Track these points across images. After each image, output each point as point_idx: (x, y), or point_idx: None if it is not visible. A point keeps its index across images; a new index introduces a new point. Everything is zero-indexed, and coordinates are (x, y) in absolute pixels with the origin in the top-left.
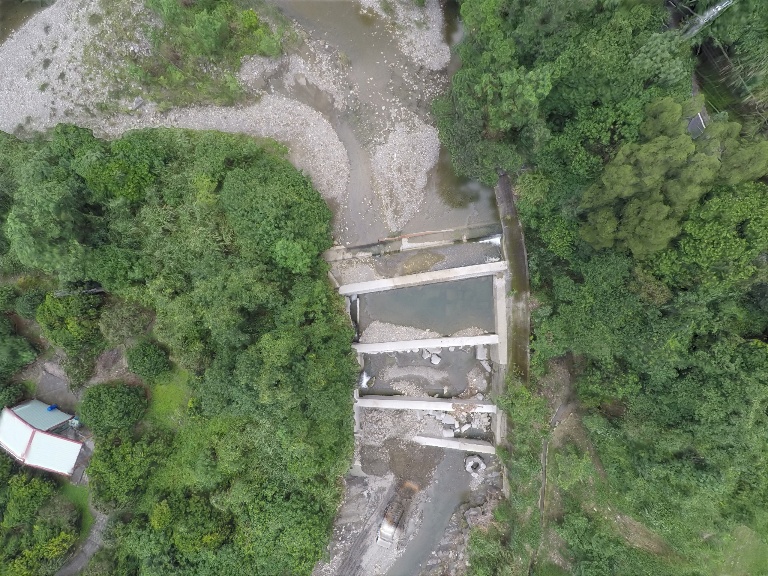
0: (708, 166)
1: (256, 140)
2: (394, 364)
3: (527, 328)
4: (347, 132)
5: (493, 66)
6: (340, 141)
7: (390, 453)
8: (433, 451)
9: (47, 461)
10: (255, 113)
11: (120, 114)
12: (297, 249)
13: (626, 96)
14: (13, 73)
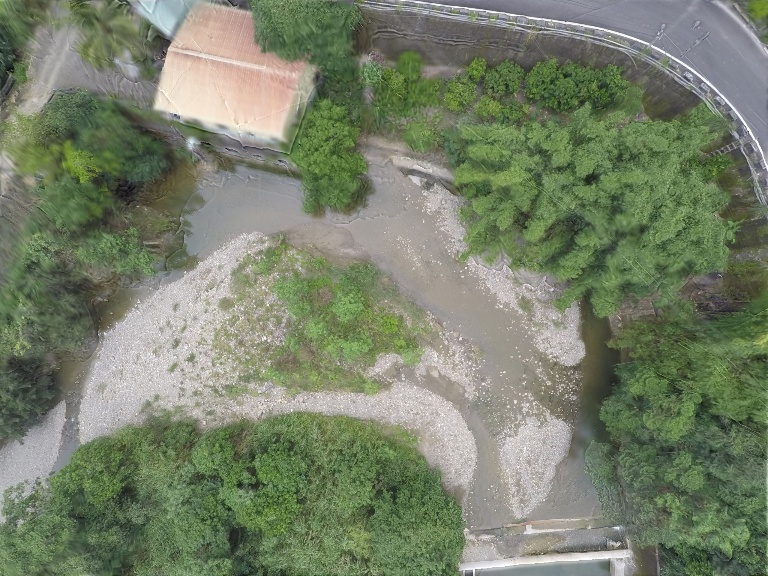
0: None
1: (386, 429)
2: None
3: None
4: (476, 421)
5: (677, 484)
6: (469, 430)
7: None
8: None
9: None
10: (385, 399)
11: (248, 394)
12: None
13: None
14: (140, 347)
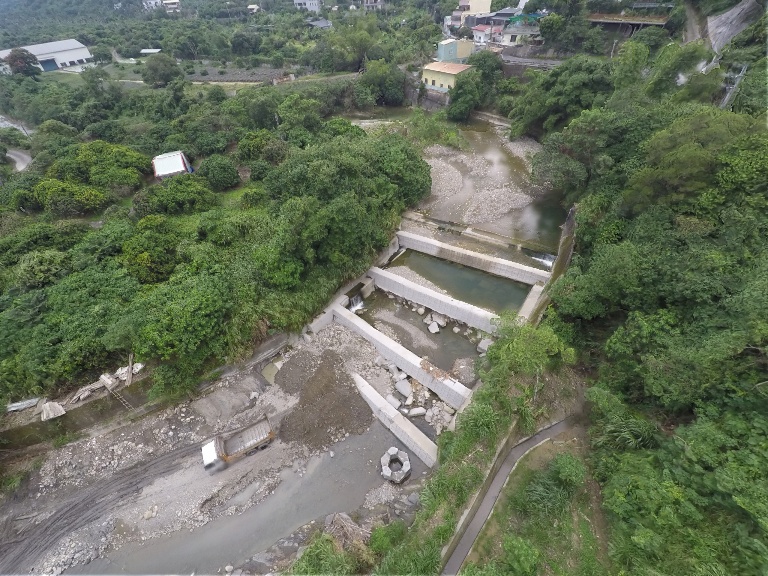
0: (735, 121)
1: None
2: (393, 311)
3: (548, 298)
4: (469, 182)
5: None
6: (462, 182)
7: (320, 367)
8: (361, 406)
9: (160, 166)
10: None
11: None
12: (402, 155)
13: (672, 123)
14: None
